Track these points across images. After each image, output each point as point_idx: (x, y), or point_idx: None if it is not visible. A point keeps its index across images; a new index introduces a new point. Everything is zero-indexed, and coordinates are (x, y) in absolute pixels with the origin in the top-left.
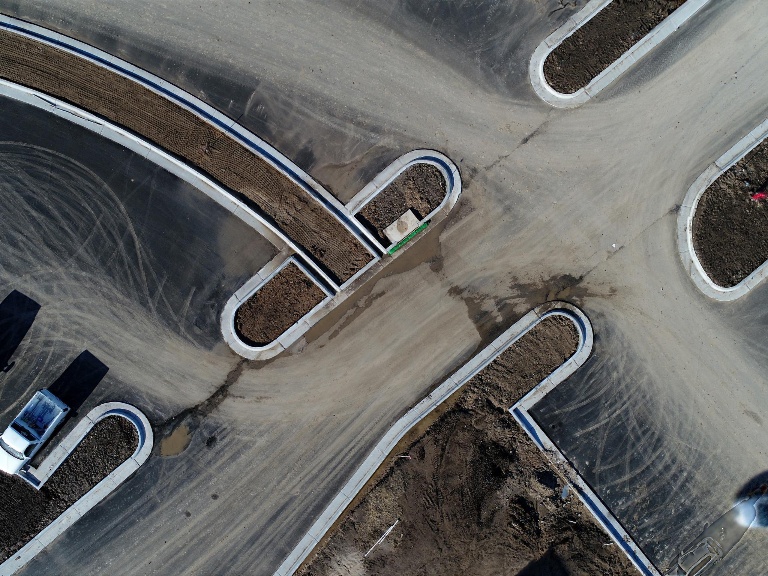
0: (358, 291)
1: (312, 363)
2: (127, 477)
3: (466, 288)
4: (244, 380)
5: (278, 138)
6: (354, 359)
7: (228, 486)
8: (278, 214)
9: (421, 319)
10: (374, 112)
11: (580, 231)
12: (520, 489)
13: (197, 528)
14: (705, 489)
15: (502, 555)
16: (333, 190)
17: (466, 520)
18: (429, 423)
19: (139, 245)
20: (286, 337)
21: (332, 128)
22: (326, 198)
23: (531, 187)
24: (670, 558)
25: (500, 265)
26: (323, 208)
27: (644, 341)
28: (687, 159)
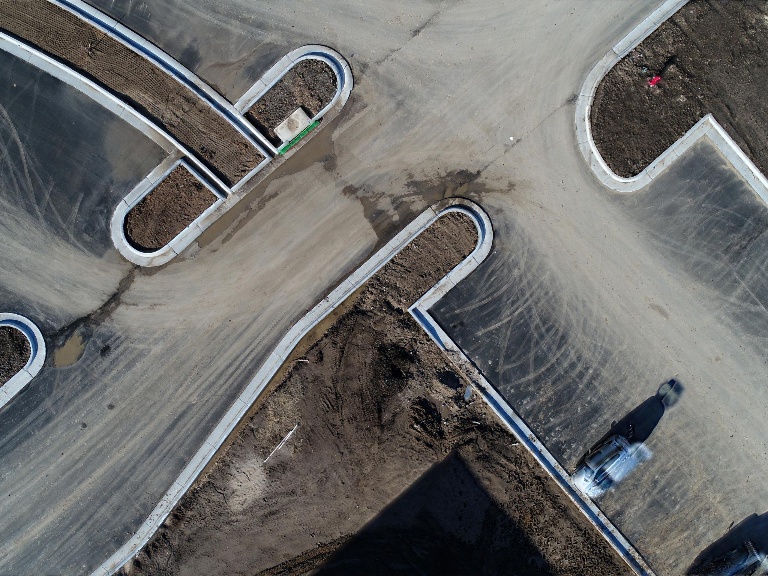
0: (250, 193)
1: (205, 268)
2: (20, 389)
3: (361, 187)
4: (137, 287)
5: (163, 37)
6: (248, 263)
7: (124, 396)
8: (166, 116)
9: (316, 220)
10: (260, 8)
11: (476, 125)
12: (421, 390)
13: (93, 439)
14: (612, 386)
15: (404, 458)
16: (221, 90)
17: (367, 423)
18: (327, 326)
19: (24, 152)
20: (178, 242)
21: (218, 25)
22: (214, 98)
23: (424, 81)
24: (577, 457)
25: (395, 162)
26: (211, 108)
27: (545, 236)
28: (584, 47)
